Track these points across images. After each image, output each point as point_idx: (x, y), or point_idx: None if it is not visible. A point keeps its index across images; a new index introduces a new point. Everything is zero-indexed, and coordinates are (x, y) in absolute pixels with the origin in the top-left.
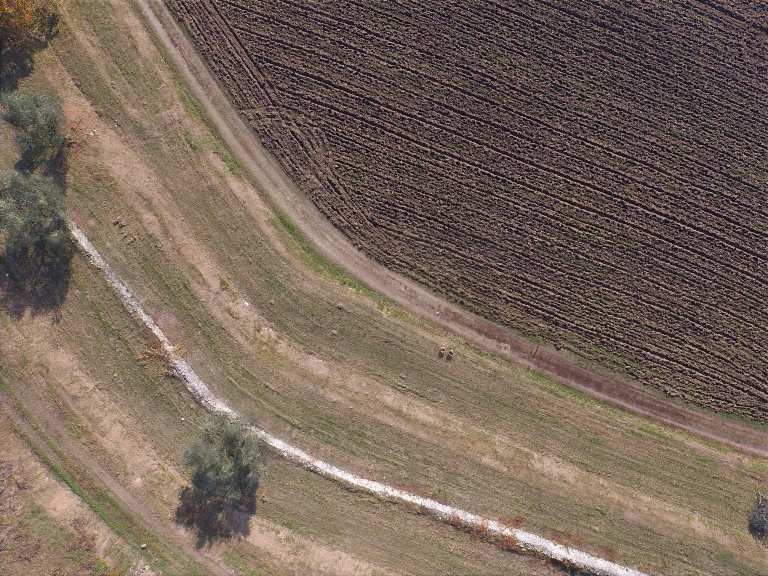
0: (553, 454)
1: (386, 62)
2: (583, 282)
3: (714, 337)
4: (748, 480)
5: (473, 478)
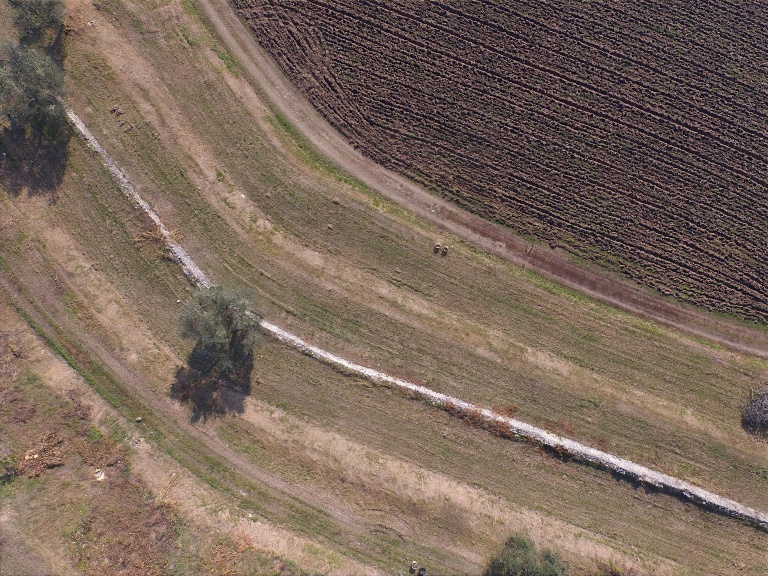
0: (547, 349)
1: None
2: (578, 181)
3: (708, 236)
4: (741, 377)
5: (467, 368)
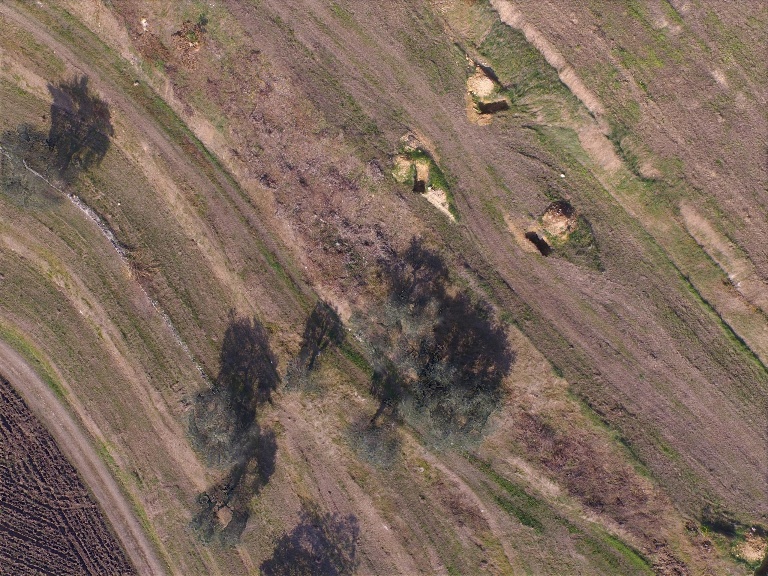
0: None
1: None
2: None
3: None
4: None
5: None
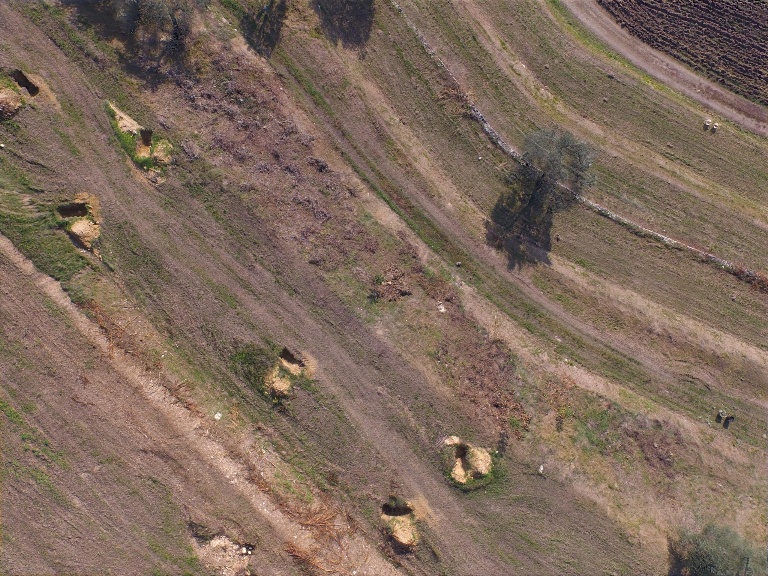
0: None
1: None
2: None
3: None
4: None
5: (746, 238)
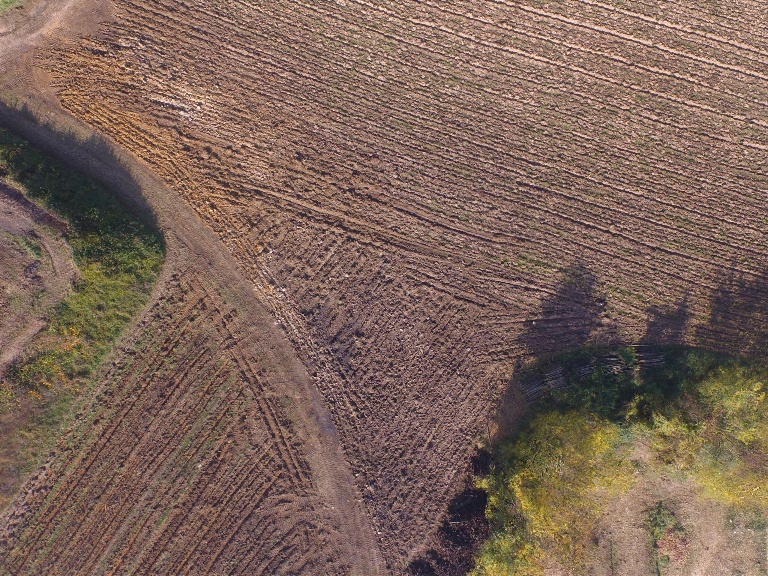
0: None
1: (759, 125)
2: None
3: None
4: None
5: None
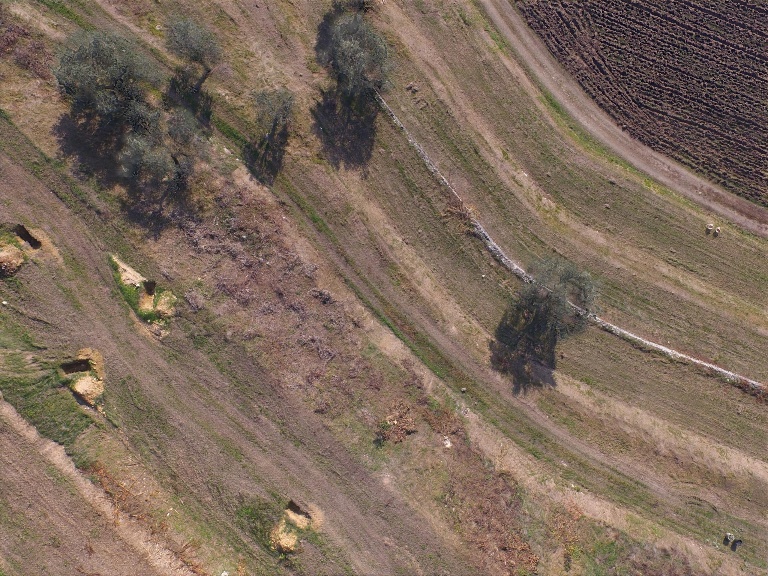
0: None
1: None
2: None
3: None
4: None
5: (751, 347)
